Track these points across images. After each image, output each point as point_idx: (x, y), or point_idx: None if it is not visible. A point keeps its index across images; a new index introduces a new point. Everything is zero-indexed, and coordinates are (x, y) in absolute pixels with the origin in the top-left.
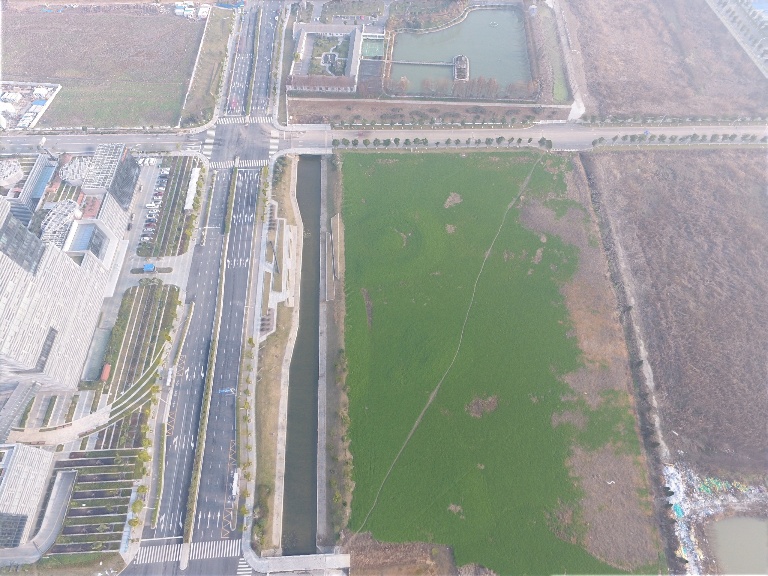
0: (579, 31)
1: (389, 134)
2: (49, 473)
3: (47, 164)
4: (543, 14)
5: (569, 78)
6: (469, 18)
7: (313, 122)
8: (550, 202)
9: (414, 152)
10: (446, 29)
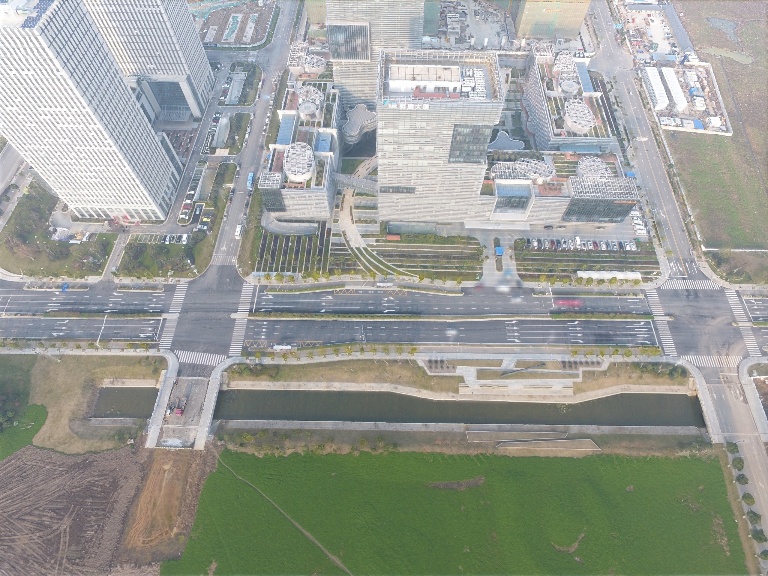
0: None
1: None
2: (318, 218)
3: (604, 147)
4: None
5: None
6: None
7: None
8: None
9: None
10: None
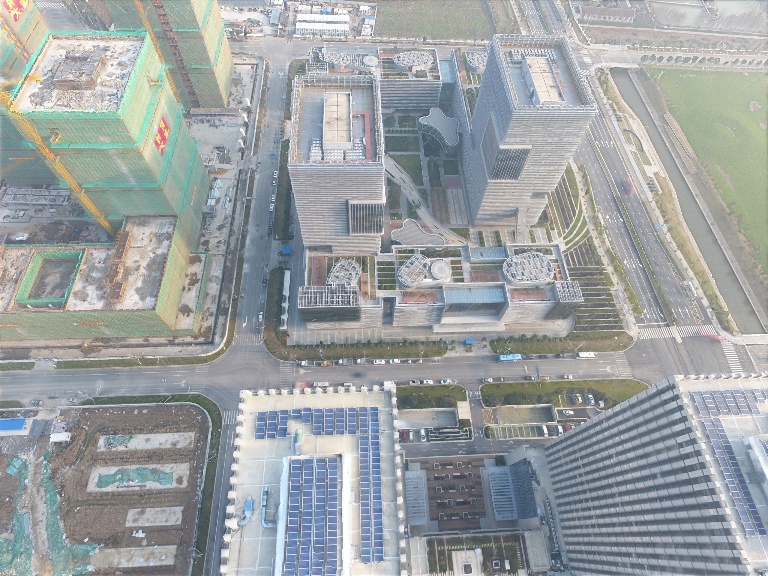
0: None
1: (678, 55)
2: None
3: None
4: None
5: None
6: None
7: (609, 44)
8: None
9: (705, 70)
10: None
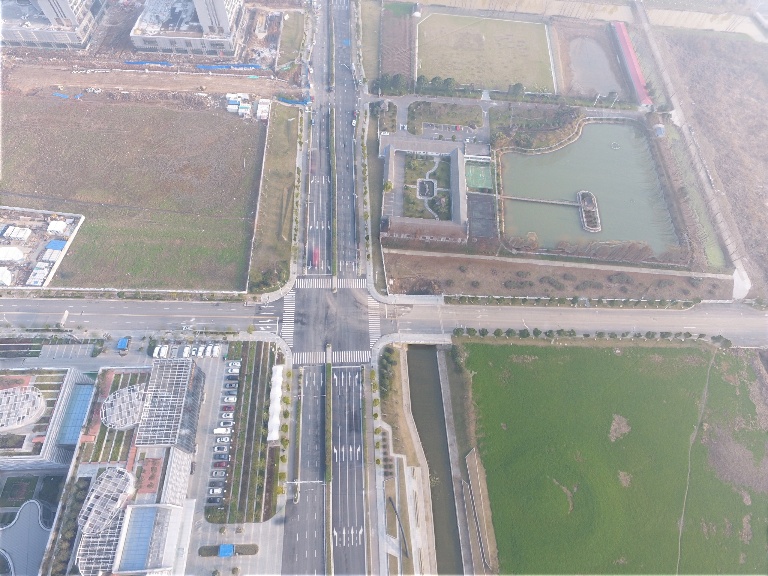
0: (716, 161)
1: (519, 313)
2: None
3: (77, 378)
4: (671, 135)
5: (723, 234)
6: (584, 135)
7: (419, 289)
8: (741, 434)
9: (555, 344)
10: (560, 149)
